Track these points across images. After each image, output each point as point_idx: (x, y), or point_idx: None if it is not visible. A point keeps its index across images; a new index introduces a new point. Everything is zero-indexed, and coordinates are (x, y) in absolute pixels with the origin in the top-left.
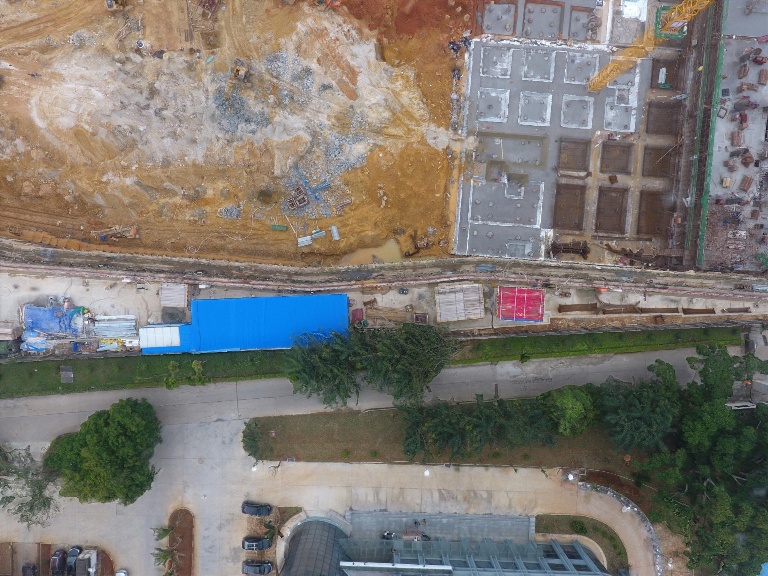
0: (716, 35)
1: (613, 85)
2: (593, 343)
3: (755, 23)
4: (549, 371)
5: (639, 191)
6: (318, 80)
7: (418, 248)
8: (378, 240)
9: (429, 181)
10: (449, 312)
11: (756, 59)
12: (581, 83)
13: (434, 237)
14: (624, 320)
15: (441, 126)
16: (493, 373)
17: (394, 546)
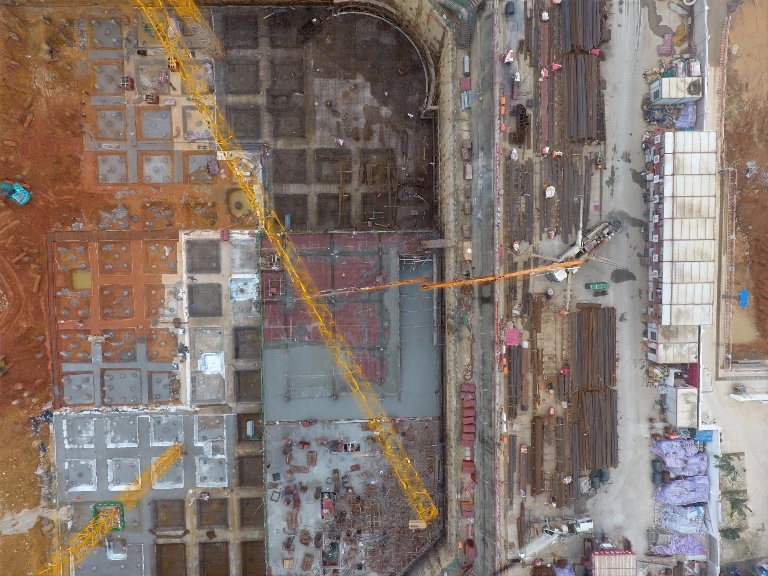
0: (260, 422)
1: (202, 441)
2: None
3: (298, 407)
4: None
5: (239, 543)
6: None
7: None
8: None
9: (14, 566)
10: None
11: None
12: (168, 444)
13: None
14: None
15: (23, 508)
16: None
17: None
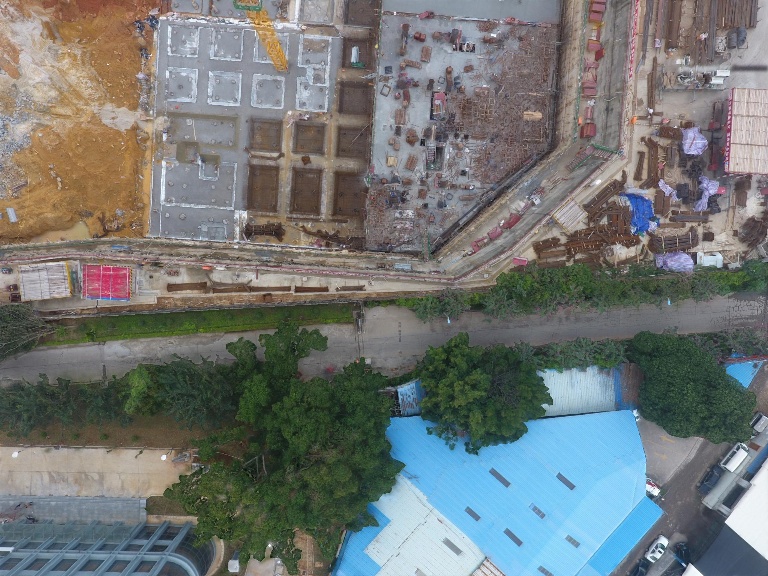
0: (377, 11)
1: (306, 64)
2: (201, 322)
3: None
4: (158, 351)
5: (333, 172)
6: None
7: (106, 231)
8: (62, 222)
9: (109, 162)
10: (33, 291)
11: (414, 36)
12: (272, 62)
13: (124, 219)
14: (233, 299)
15: (123, 106)
16: (101, 353)
17: None
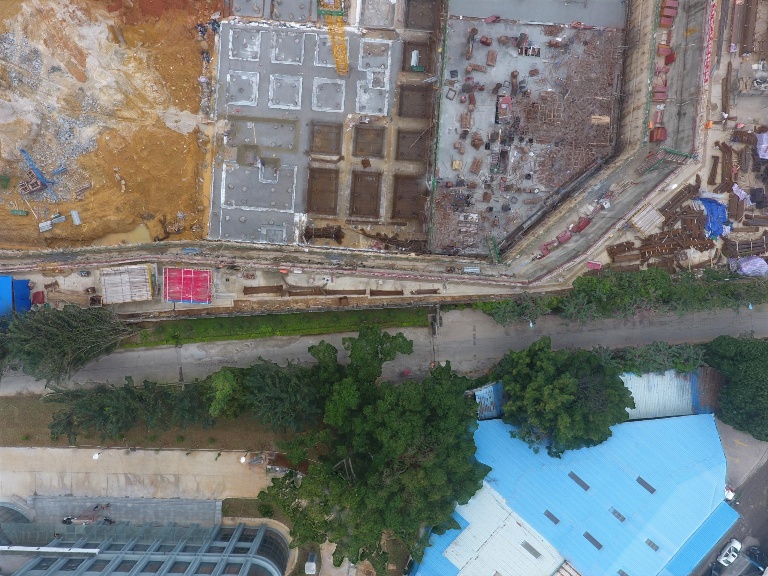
0: (443, 16)
1: (366, 68)
2: (277, 325)
3: (482, 4)
4: (234, 354)
5: (392, 175)
6: (46, 62)
7: (167, 233)
8: (124, 225)
9: (172, 165)
10: (115, 294)
11: (481, 40)
12: (332, 66)
13: (185, 222)
14: (309, 302)
15: (185, 109)
16: (177, 356)
17: (56, 530)
